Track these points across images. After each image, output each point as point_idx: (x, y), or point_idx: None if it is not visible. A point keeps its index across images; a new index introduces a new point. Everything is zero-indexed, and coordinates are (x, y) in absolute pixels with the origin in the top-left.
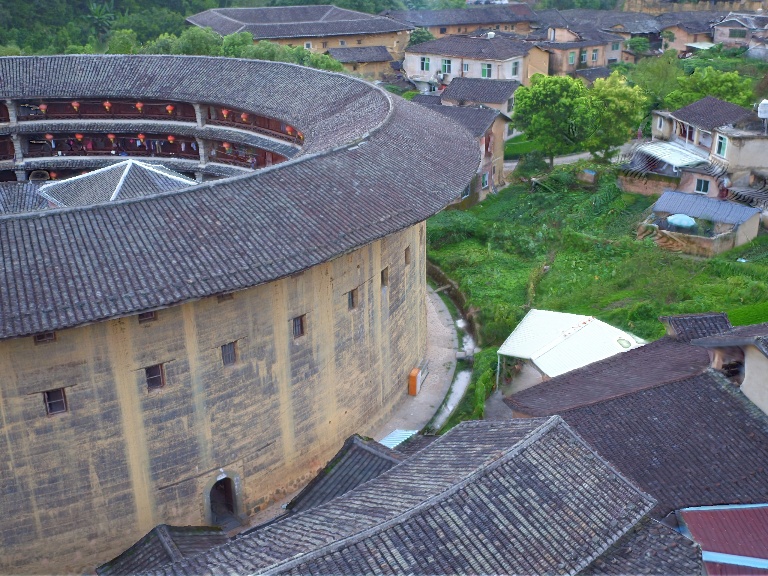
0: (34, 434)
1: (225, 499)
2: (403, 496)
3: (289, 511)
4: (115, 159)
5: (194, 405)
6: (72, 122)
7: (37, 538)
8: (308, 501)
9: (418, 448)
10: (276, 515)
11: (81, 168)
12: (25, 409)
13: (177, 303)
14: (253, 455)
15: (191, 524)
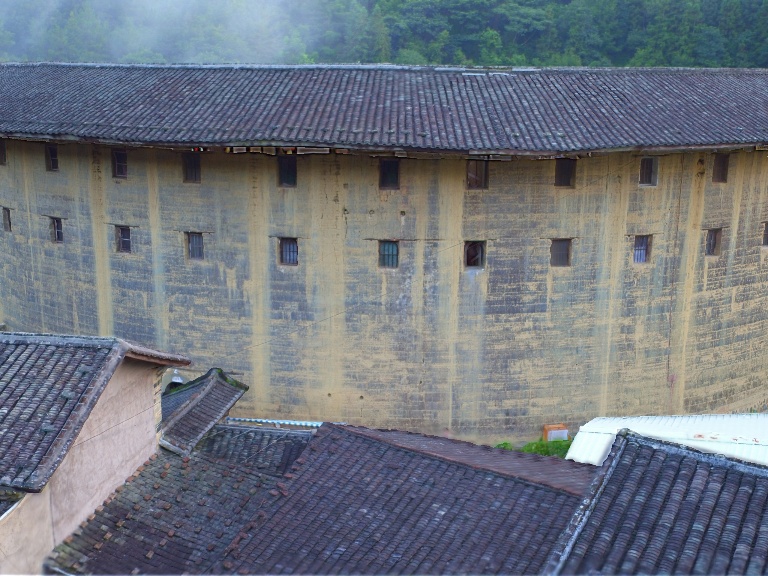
0: (44, 254)
1: None
2: None
3: None
4: None
5: (155, 284)
6: None
7: None
8: None
9: None
10: None
11: None
12: (40, 228)
13: (60, 136)
14: None
15: None
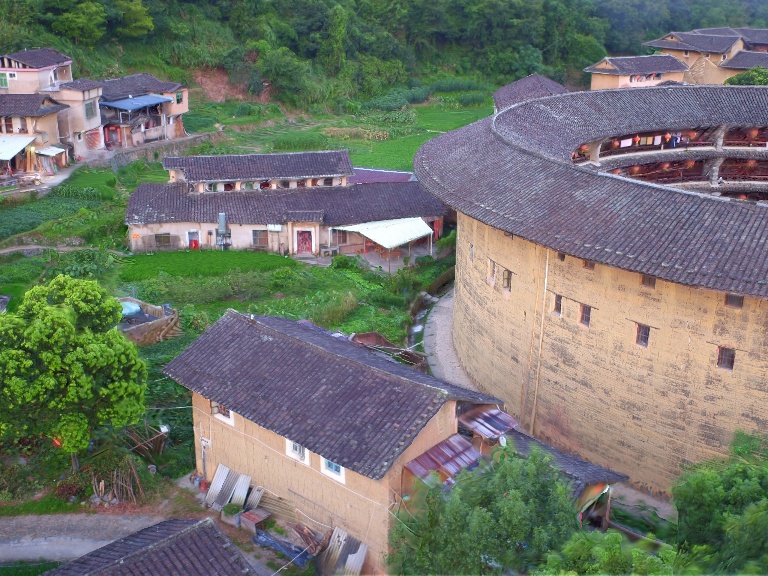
0: None
1: None
2: None
3: None
4: None
5: None
6: None
7: None
8: None
9: None
10: None
11: None
12: None
13: None
14: None
15: None
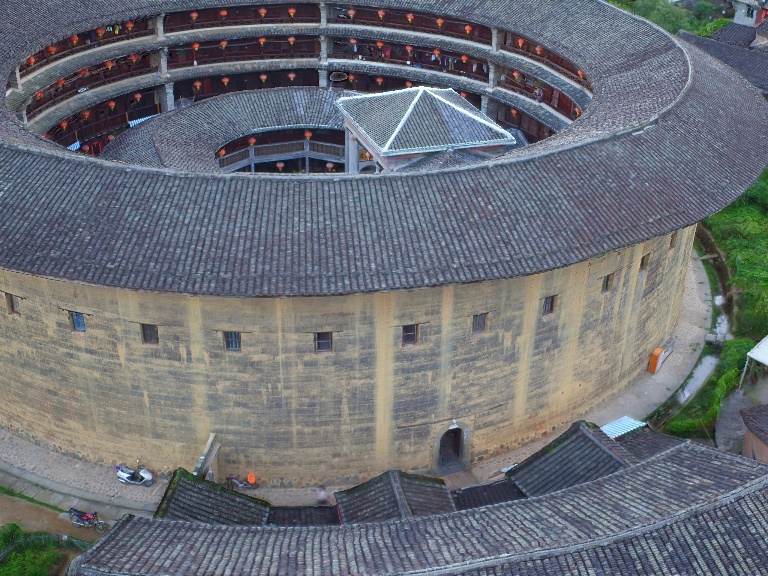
0: (302, 365)
1: (453, 445)
2: (612, 515)
3: (507, 478)
4: (409, 70)
5: (440, 363)
6: (376, 29)
7: (292, 447)
8: (526, 473)
9: (642, 443)
10: (496, 468)
11: (377, 75)
12: (298, 344)
13: (439, 285)
14: (485, 412)
15: (420, 461)
